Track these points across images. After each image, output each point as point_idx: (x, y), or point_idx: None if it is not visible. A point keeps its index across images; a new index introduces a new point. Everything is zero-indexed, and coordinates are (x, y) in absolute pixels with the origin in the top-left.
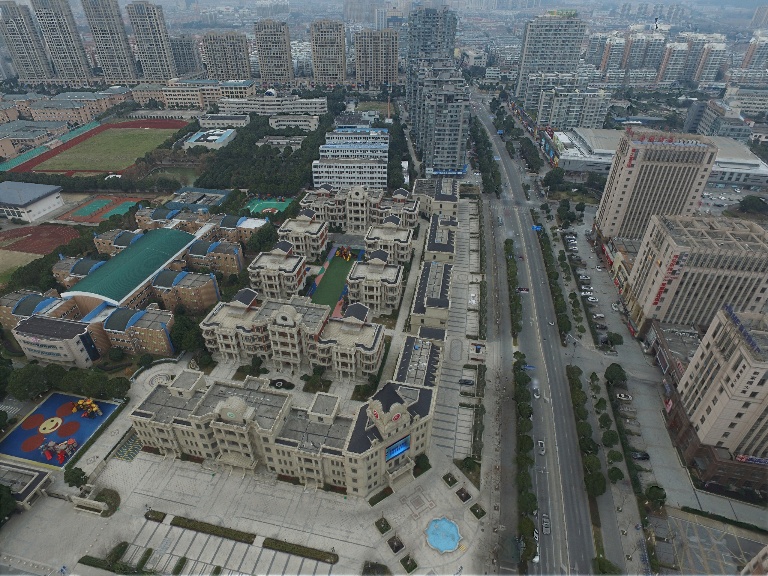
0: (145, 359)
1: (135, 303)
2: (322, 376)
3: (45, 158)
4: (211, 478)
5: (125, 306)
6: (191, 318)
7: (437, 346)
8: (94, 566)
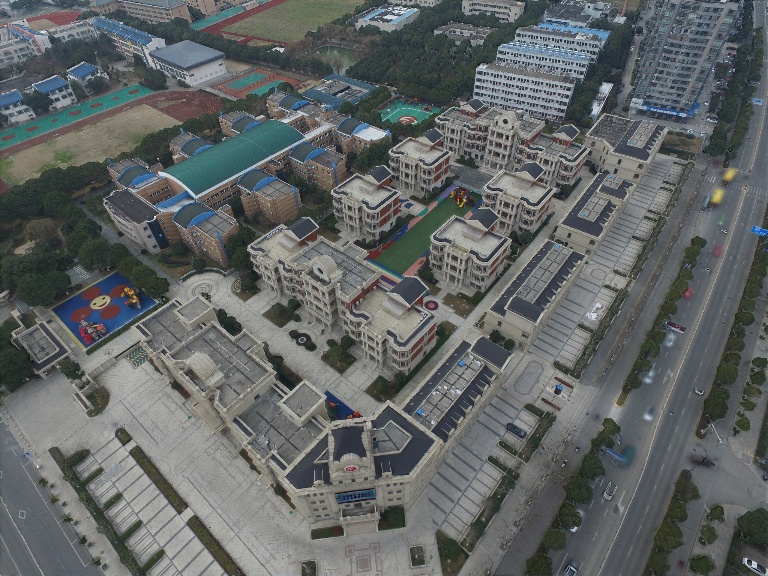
0: (197, 264)
1: (217, 199)
2: (350, 348)
3: (237, 19)
4: (186, 420)
5: (205, 200)
6: (264, 230)
7: (491, 371)
8: (56, 461)
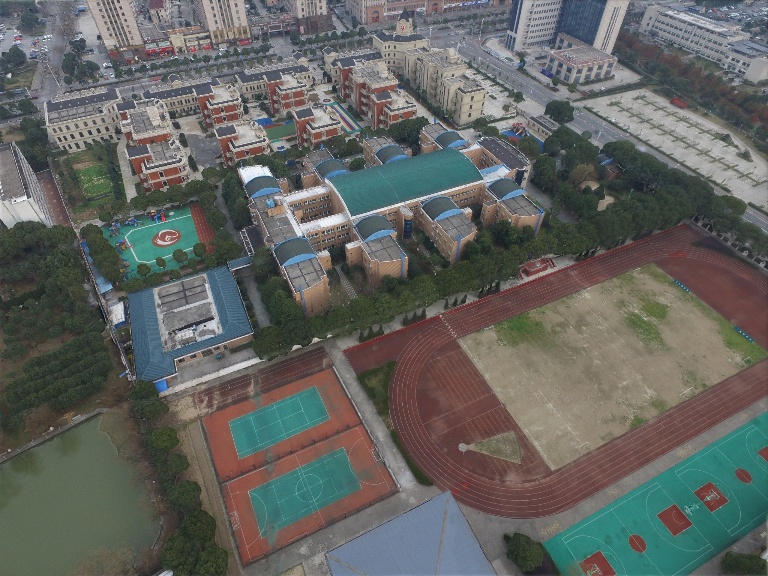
0: None
1: None
2: None
3: None
4: None
5: None
6: None
7: None
8: None
